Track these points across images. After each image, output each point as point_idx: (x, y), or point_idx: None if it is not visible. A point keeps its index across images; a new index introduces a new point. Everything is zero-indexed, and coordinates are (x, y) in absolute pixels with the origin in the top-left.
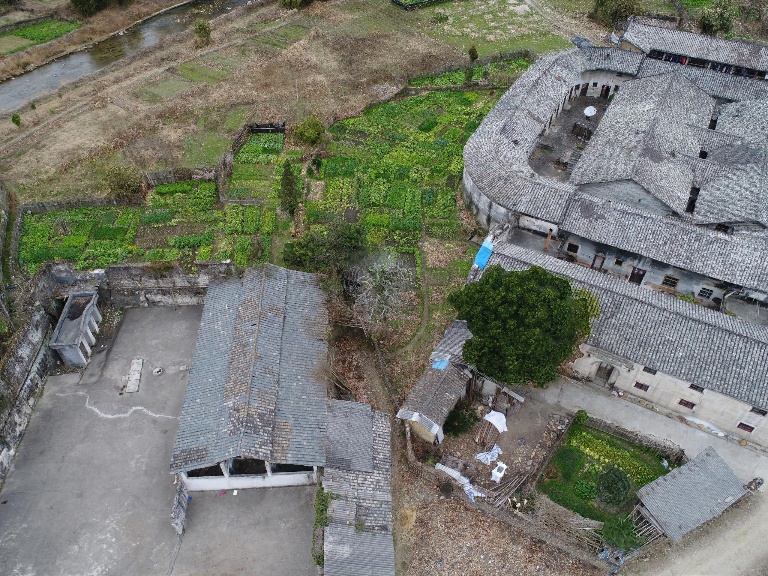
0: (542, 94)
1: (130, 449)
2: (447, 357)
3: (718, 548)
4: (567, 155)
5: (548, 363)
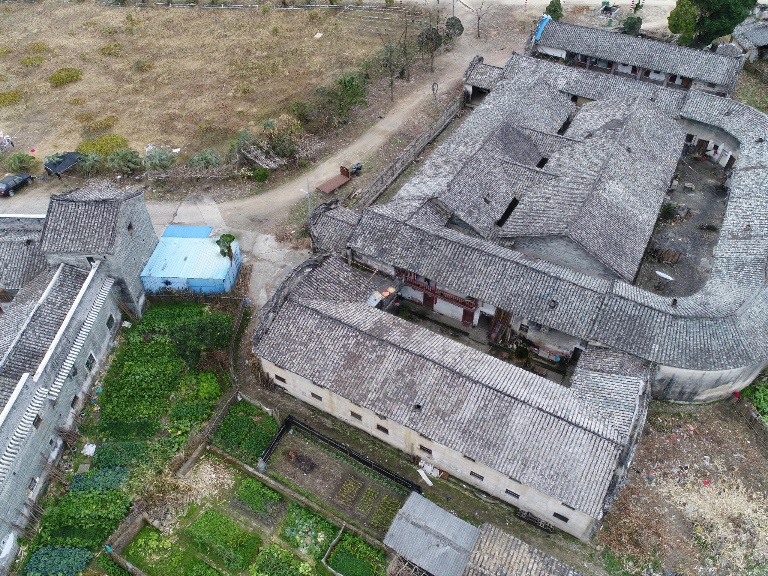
0: (760, 193)
1: None
2: None
3: None
4: (684, 206)
5: None
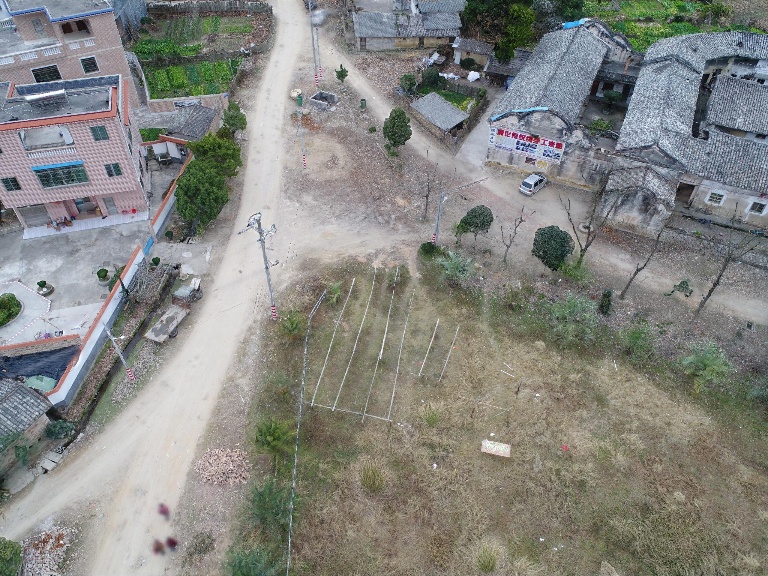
0: None
1: None
2: None
3: (414, 133)
4: None
5: (472, 7)
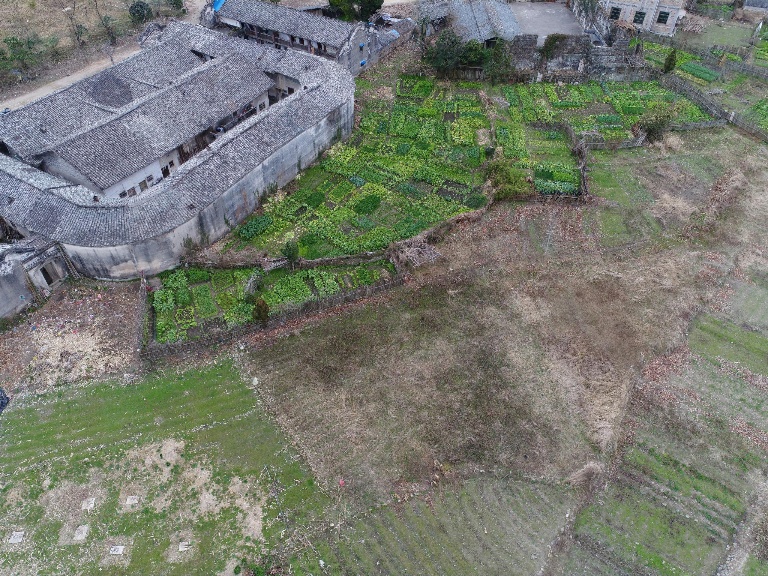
0: None
1: (535, 29)
2: (391, 32)
3: None
4: None
5: None
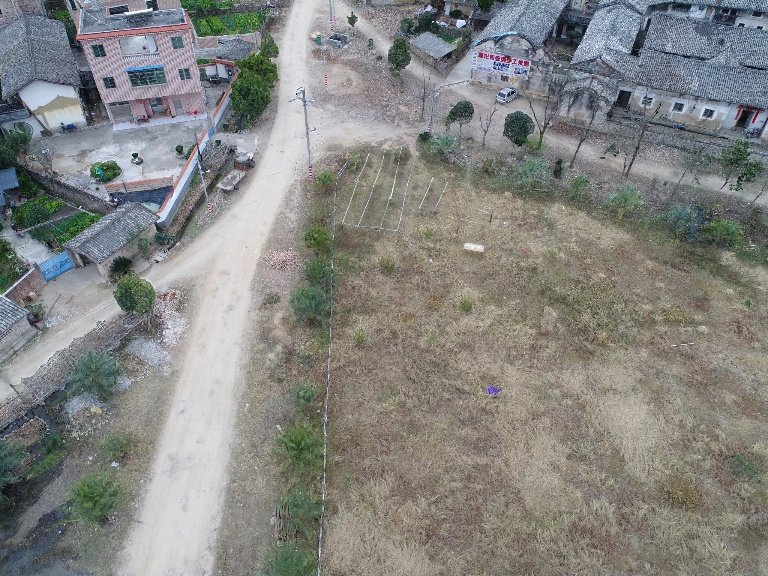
0: None
1: None
2: None
3: (412, 63)
4: None
5: None
